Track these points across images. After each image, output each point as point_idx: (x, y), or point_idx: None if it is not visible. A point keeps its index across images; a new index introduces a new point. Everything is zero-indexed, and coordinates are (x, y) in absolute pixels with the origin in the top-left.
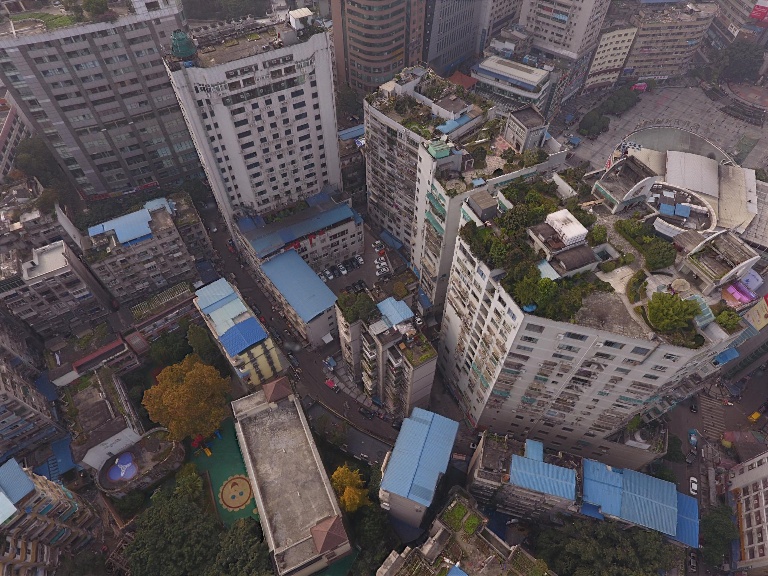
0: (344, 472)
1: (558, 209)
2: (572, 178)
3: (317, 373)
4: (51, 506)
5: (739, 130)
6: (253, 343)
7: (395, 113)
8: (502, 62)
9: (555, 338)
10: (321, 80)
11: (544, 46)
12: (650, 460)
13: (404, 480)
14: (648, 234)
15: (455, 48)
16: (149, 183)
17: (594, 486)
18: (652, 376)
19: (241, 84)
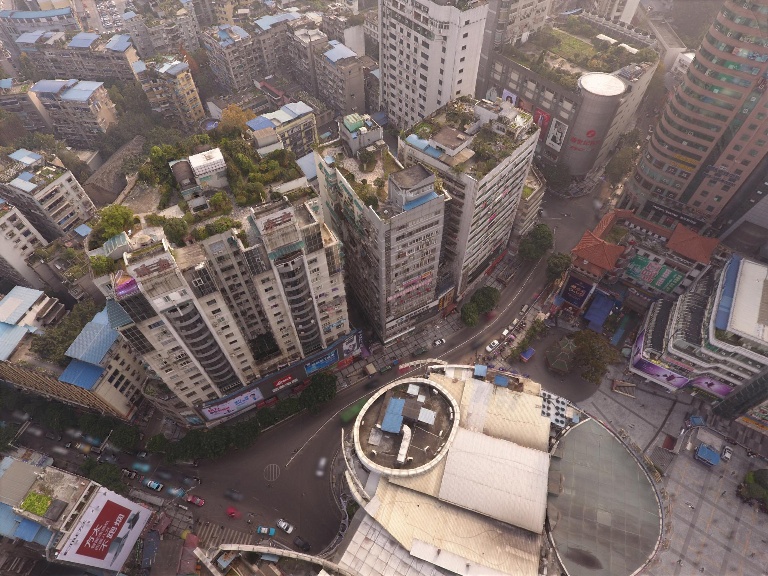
0: None
1: (265, 188)
2: None
3: None
4: (178, 93)
5: None
6: (253, 128)
7: None
8: None
9: None
10: (450, 52)
11: None
12: None
13: None
14: None
15: None
16: None
17: None
18: None
19: (399, 6)
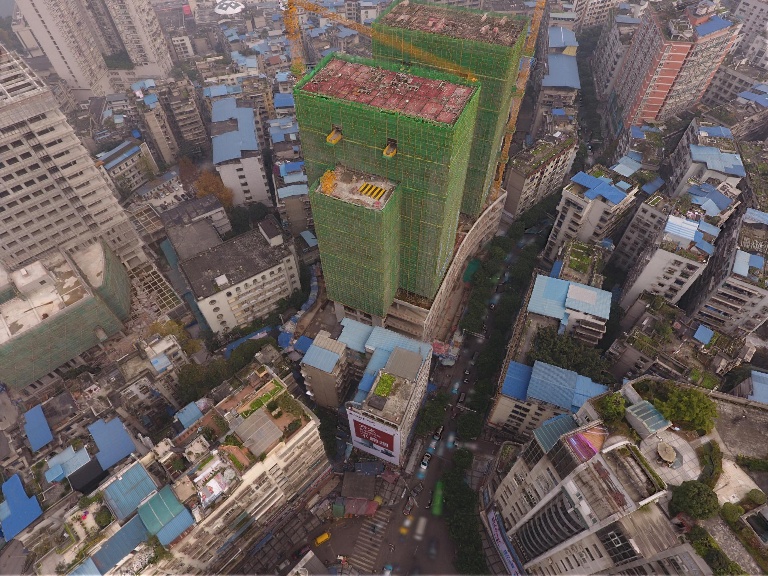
0: None
1: None
2: None
3: None
4: None
5: None
6: None
7: None
8: None
9: None
10: None
11: None
12: None
13: None
14: None
15: None
16: None
17: None
18: None
19: None
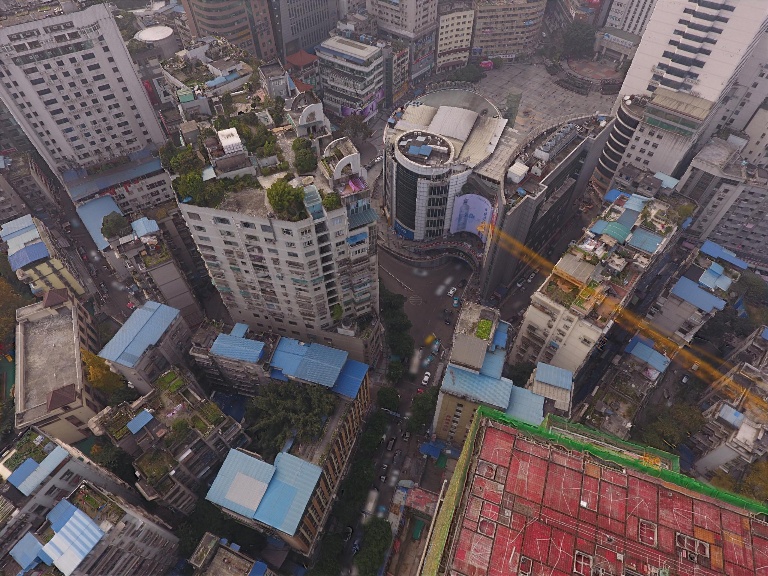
0: (85, 352)
1: None
2: (274, 111)
3: (122, 298)
4: None
5: (565, 99)
6: (35, 260)
7: (183, 74)
8: (341, 41)
9: (212, 224)
10: (113, 46)
11: (388, 28)
12: (363, 347)
13: (118, 350)
14: (305, 147)
15: (314, 32)
16: (8, 149)
17: (282, 355)
18: (294, 254)
19: (27, 46)
